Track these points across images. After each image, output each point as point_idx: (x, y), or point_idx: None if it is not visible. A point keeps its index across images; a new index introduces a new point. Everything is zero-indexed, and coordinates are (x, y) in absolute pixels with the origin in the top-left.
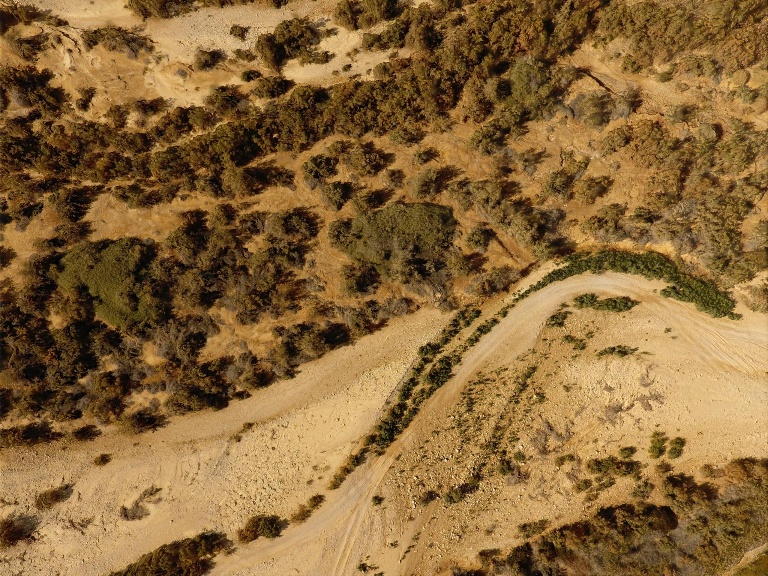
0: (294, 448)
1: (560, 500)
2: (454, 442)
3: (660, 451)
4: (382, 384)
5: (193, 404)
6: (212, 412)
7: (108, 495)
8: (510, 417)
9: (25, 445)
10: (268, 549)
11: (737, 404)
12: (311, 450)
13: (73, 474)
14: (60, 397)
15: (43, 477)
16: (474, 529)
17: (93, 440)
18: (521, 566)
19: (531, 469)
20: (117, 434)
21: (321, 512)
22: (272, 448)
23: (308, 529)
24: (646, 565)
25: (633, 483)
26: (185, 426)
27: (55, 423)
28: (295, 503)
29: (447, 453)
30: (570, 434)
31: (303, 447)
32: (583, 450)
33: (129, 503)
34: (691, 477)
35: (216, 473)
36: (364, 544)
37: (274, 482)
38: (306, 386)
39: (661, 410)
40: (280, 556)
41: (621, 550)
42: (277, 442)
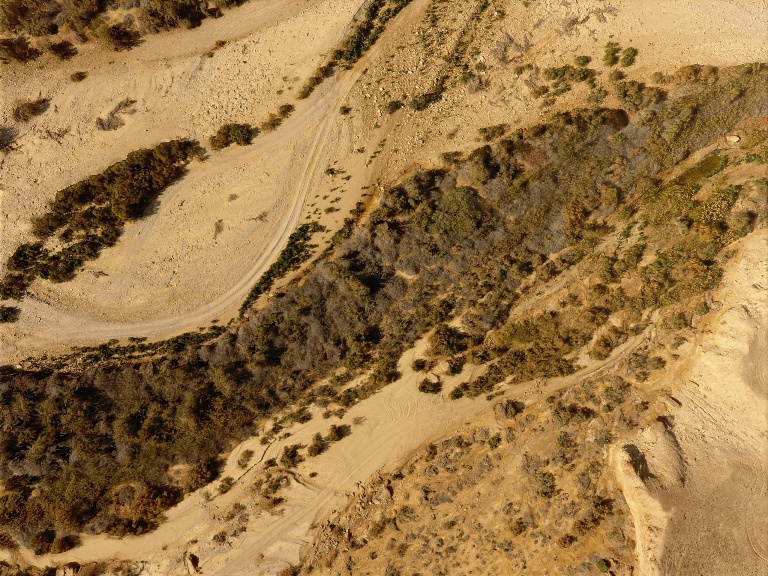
0: (265, 61)
1: (519, 105)
2: (418, 56)
3: (613, 58)
4: (350, 2)
5: (166, 6)
6: (185, 31)
7: (84, 107)
8: (472, 34)
9: (2, 55)
10: (240, 156)
11: (686, 16)
12: (281, 63)
13: (50, 89)
14: (37, 16)
15: (20, 92)
16: (437, 134)
17: (69, 59)
18: (481, 157)
19: (491, 78)
20: (93, 53)
21: (291, 121)
22: (243, 62)
23: (278, 137)
24: (599, 157)
25: (588, 90)
26: (159, 45)
27: (32, 38)
28: (266, 112)
29: (412, 66)
30: (529, 44)
31: (273, 60)
32: (541, 60)
33: (105, 114)
34: (642, 83)
35: (189, 86)
36: (332, 150)
37: (245, 92)
38: (276, 6)
39: (615, 22)
40: (251, 162)
41: (575, 140)
42: (248, 56)
